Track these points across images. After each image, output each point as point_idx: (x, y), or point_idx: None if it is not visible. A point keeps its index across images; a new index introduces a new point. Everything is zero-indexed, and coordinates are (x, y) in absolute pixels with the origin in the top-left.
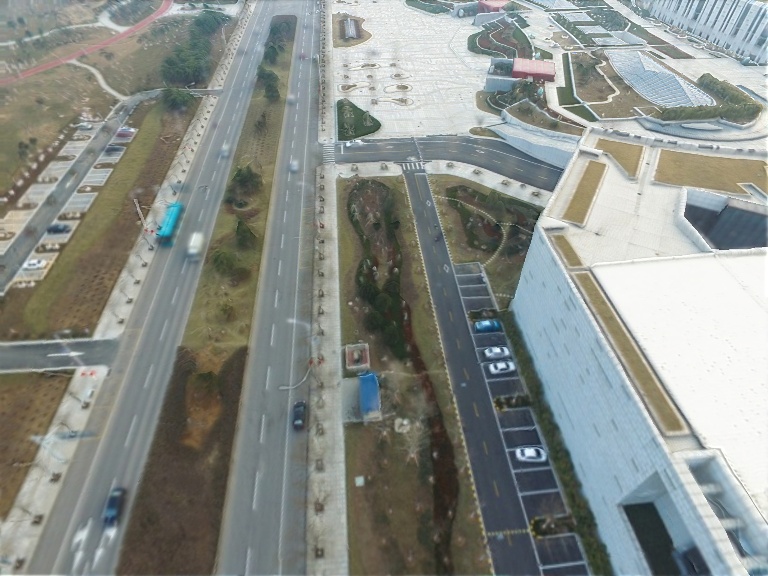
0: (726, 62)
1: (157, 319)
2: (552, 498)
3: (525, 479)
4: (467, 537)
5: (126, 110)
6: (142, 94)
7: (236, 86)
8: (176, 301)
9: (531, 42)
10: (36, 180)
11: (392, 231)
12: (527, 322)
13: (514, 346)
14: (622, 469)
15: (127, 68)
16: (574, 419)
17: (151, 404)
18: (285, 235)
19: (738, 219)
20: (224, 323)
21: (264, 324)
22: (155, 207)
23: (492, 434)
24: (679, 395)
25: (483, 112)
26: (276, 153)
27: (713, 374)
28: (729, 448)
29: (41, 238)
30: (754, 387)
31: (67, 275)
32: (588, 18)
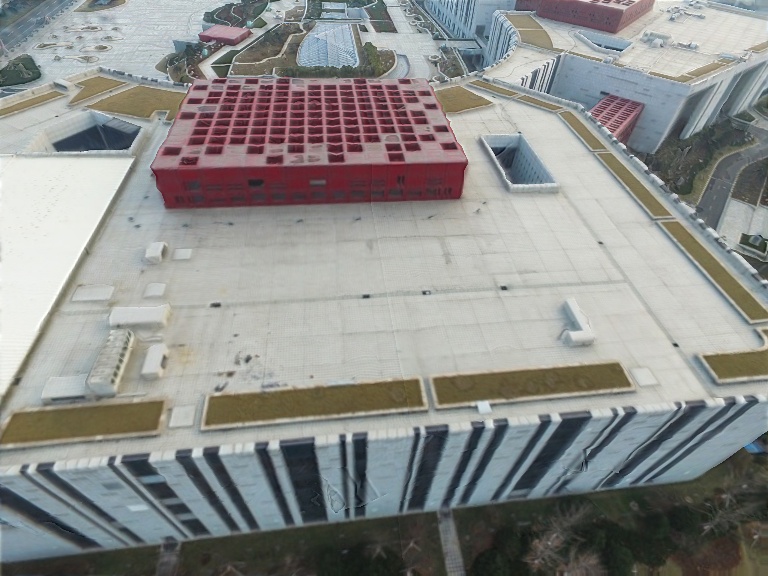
0: (421, 36)
1: None
2: None
3: None
4: None
5: None
6: None
7: None
8: None
9: (262, 14)
10: None
11: None
12: None
13: None
14: None
15: None
16: None
17: None
18: None
19: (114, 136)
20: None
21: None
22: None
23: None
24: None
25: (156, 71)
26: None
27: None
28: None
29: None
30: None
31: None
32: None
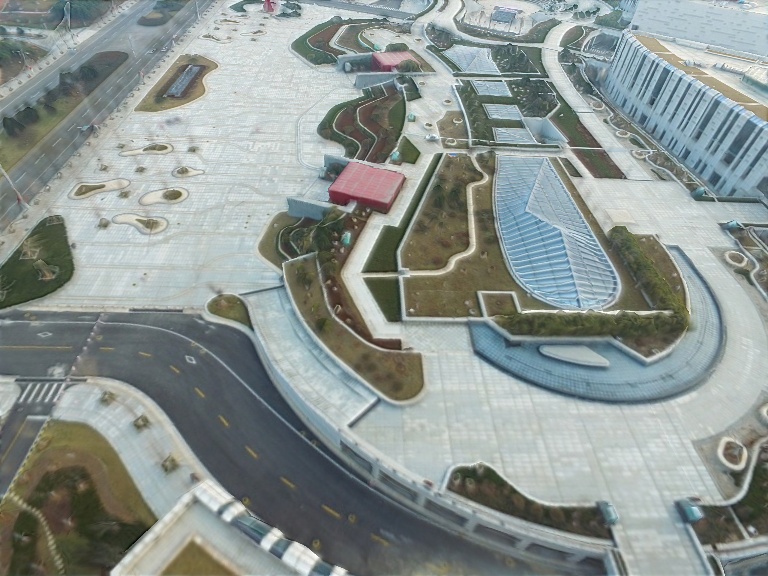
0: (670, 190)
1: None
2: None
3: None
4: None
5: None
6: None
7: None
8: None
9: (404, 127)
10: None
11: None
12: None
13: None
14: None
15: None
16: None
17: None
18: None
19: None
20: None
21: None
22: None
23: None
24: None
25: (261, 258)
26: None
27: None
28: None
29: None
30: None
31: None
32: (505, 92)
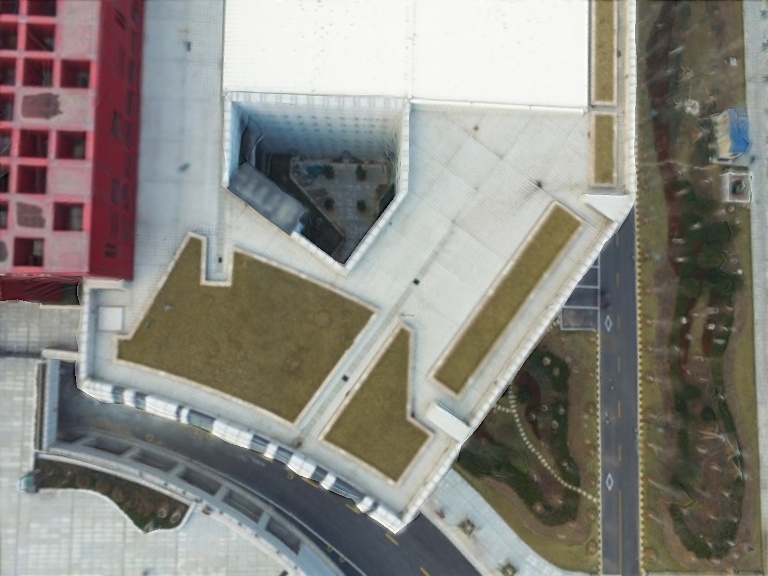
0: None
1: None
2: None
3: None
4: (648, 7)
5: None
6: None
7: None
8: None
9: None
10: None
11: (680, 408)
12: None
13: None
14: None
15: None
16: None
17: None
18: None
19: None
20: None
21: None
22: None
23: None
24: None
25: None
26: None
27: None
28: None
29: None
30: None
31: None
32: None
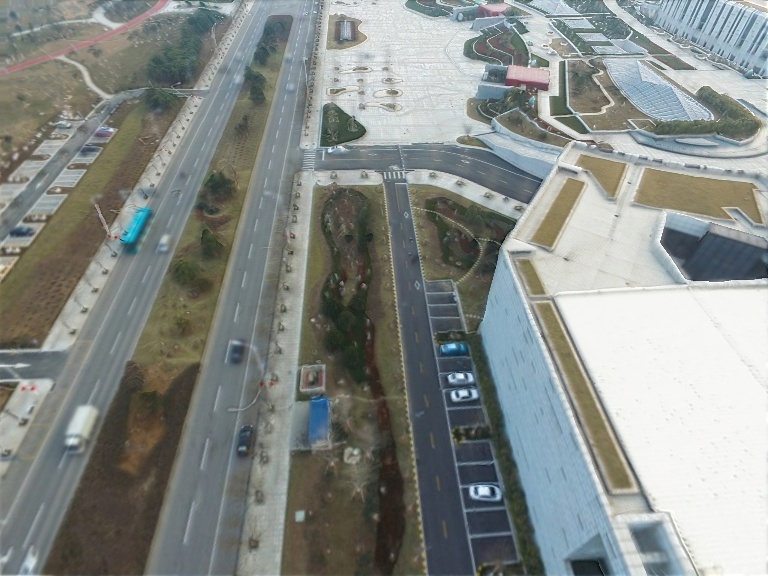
0: (728, 74)
1: (110, 331)
2: (504, 542)
3: (477, 520)
4: None
5: (108, 109)
6: (126, 93)
7: (223, 87)
8: (132, 312)
9: (528, 49)
10: (7, 180)
11: (365, 244)
12: (492, 348)
13: (479, 372)
14: (569, 523)
15: (115, 66)
16: (529, 459)
17: (92, 423)
18: (254, 245)
19: (719, 246)
20: (178, 337)
21: (220, 340)
22: (124, 211)
23: (447, 468)
24: (632, 447)
25: (473, 120)
26: (255, 158)
27: (672, 424)
28: (680, 512)
29: (3, 241)
30: (715, 440)
31: (24, 281)
32: (589, 25)
